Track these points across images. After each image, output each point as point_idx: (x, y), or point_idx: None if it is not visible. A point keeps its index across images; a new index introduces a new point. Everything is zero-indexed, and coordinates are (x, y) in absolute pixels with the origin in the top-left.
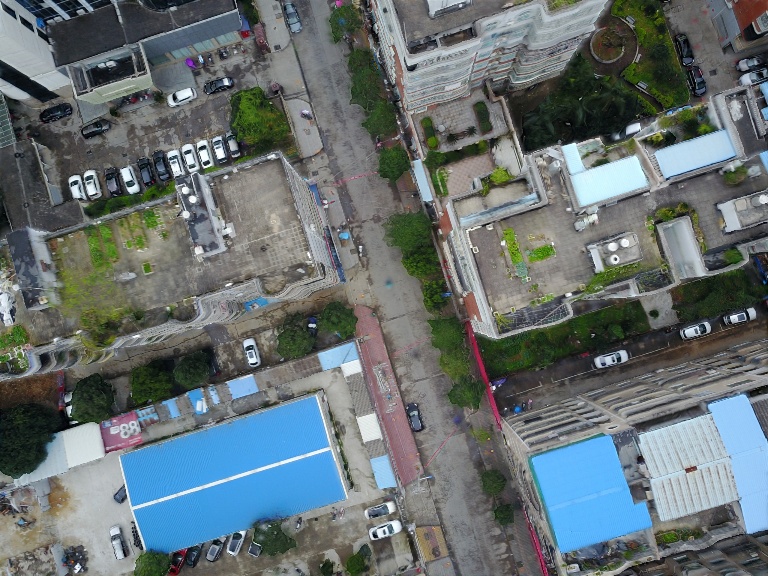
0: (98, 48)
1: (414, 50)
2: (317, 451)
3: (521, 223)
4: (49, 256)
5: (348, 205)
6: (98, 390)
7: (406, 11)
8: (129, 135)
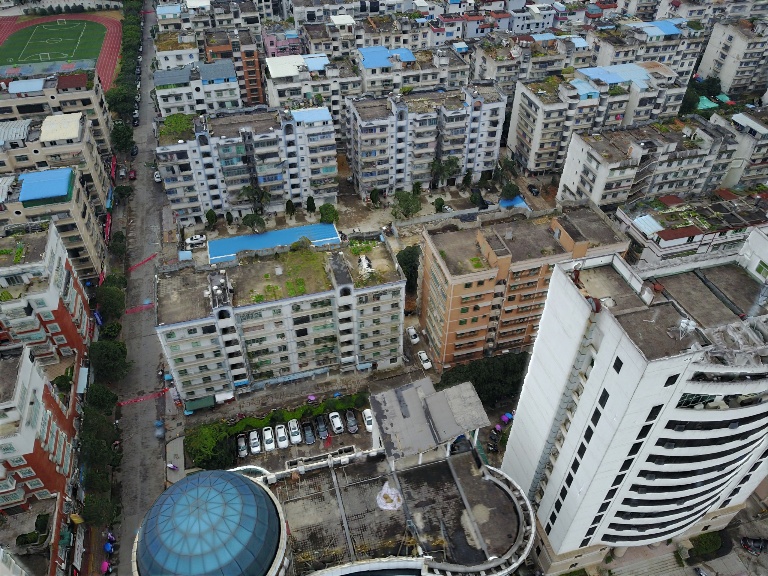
0: None
1: None
2: (218, 257)
3: None
4: None
5: (160, 403)
6: None
7: (11, 375)
8: None
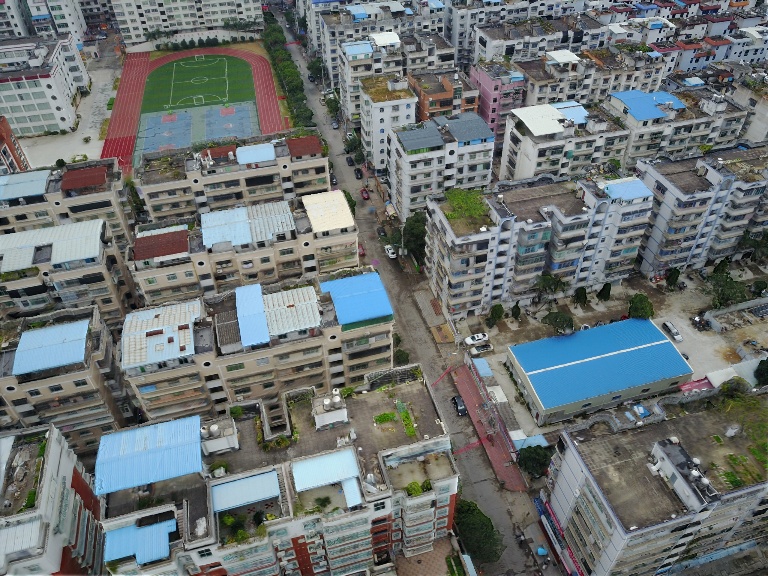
0: None
1: None
2: (537, 372)
3: (400, 441)
4: None
5: None
6: None
7: None
8: None
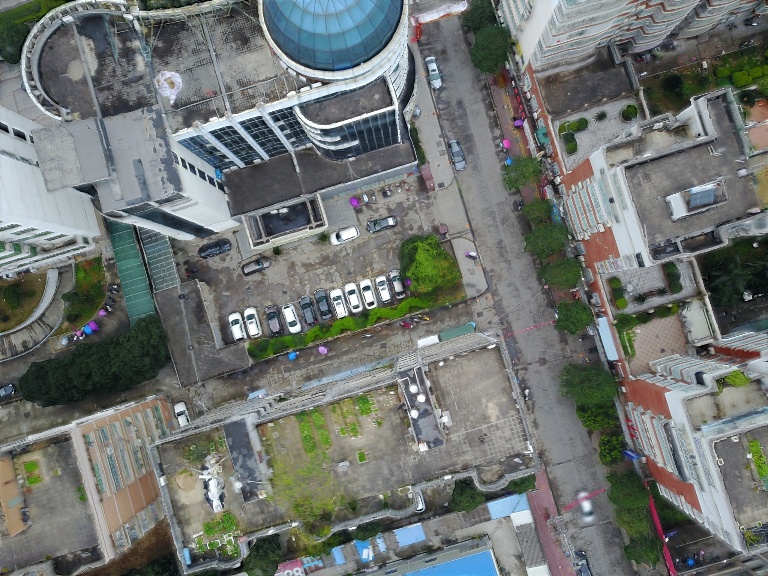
0: (274, 197)
1: (653, 252)
2: None
3: (767, 435)
4: (260, 442)
5: (513, 347)
6: (271, 544)
7: (647, 213)
8: (289, 272)
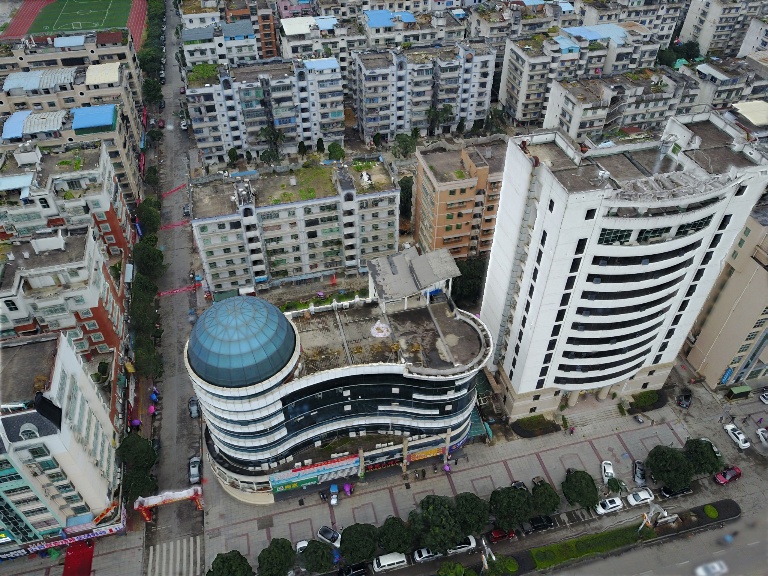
0: None
1: None
2: None
3: None
4: None
5: (192, 298)
6: None
7: (80, 245)
8: None
